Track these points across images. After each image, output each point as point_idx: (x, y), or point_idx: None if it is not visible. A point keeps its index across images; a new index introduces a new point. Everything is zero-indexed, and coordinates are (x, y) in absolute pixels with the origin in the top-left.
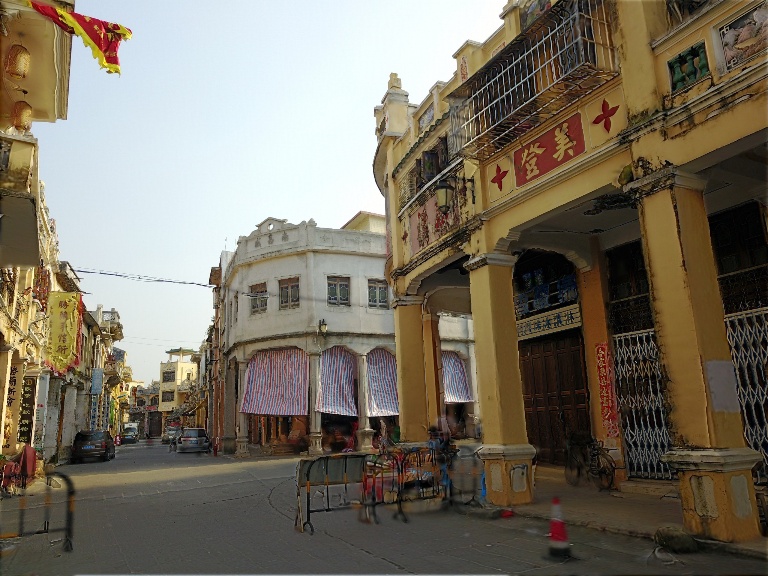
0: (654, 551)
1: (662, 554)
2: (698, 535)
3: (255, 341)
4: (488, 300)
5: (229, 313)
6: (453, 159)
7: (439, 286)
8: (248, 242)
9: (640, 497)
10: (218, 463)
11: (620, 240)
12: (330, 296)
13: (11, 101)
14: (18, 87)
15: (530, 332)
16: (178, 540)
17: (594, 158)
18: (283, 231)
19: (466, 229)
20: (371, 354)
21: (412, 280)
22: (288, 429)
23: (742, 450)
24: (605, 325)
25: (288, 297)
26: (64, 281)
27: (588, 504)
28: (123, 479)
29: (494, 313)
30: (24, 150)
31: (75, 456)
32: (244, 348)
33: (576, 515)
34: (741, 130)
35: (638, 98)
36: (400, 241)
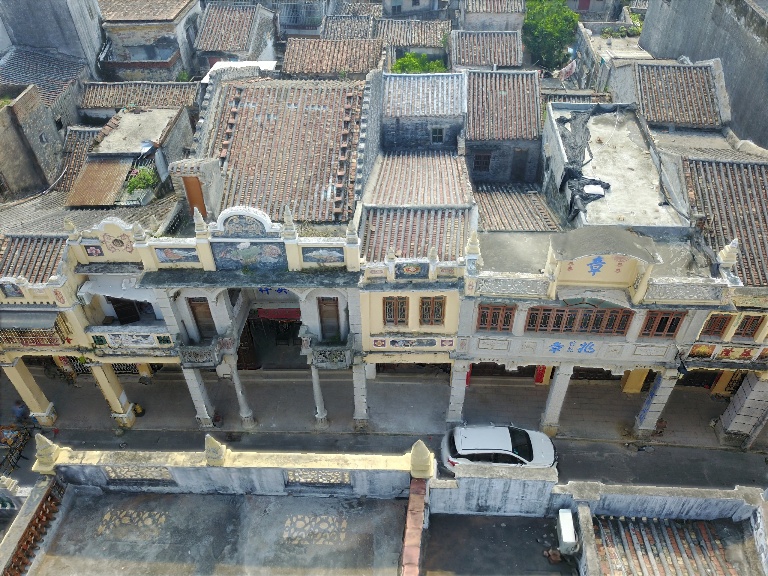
0: (120, 446)
1: (122, 446)
2: (124, 426)
3: None
4: None
5: None
6: None
7: None
8: None
9: (86, 385)
10: None
11: None
12: None
13: None
14: None
15: None
16: None
17: None
18: None
19: None
20: None
21: None
22: None
23: (130, 408)
24: None
25: None
26: None
27: (75, 405)
28: None
29: None
30: None
31: None
32: None
33: (81, 422)
34: None
35: (83, 343)
36: None
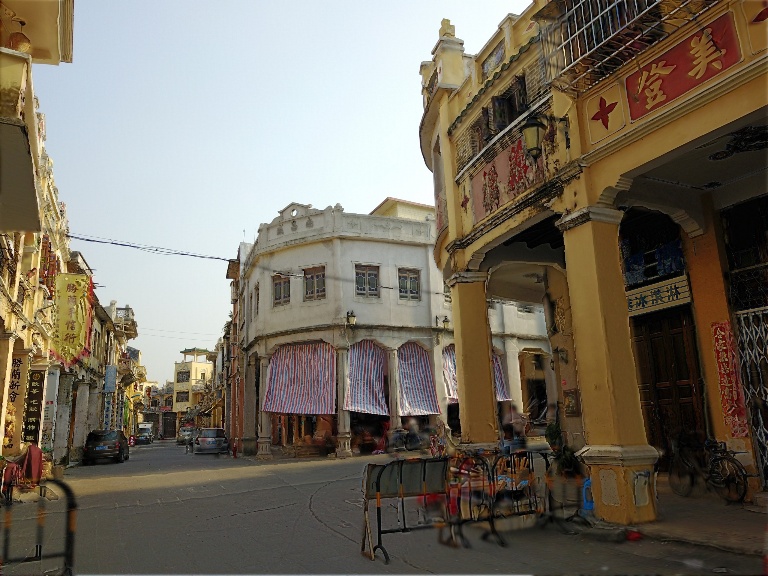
0: None
1: None
2: None
3: (278, 335)
4: (592, 264)
5: (249, 306)
6: (534, 100)
7: (504, 261)
8: (270, 229)
9: None
10: (240, 465)
11: (744, 195)
12: (358, 286)
13: (5, 31)
14: (14, 15)
15: None
16: (210, 568)
17: (760, 64)
18: (307, 217)
19: (556, 181)
20: (402, 348)
21: (475, 252)
22: (312, 429)
23: None
24: (725, 300)
25: (313, 287)
26: (75, 271)
27: (731, 522)
28: (138, 483)
29: (601, 280)
30: (13, 66)
31: (87, 457)
32: (266, 342)
33: (735, 539)
34: None
35: None
36: (458, 208)
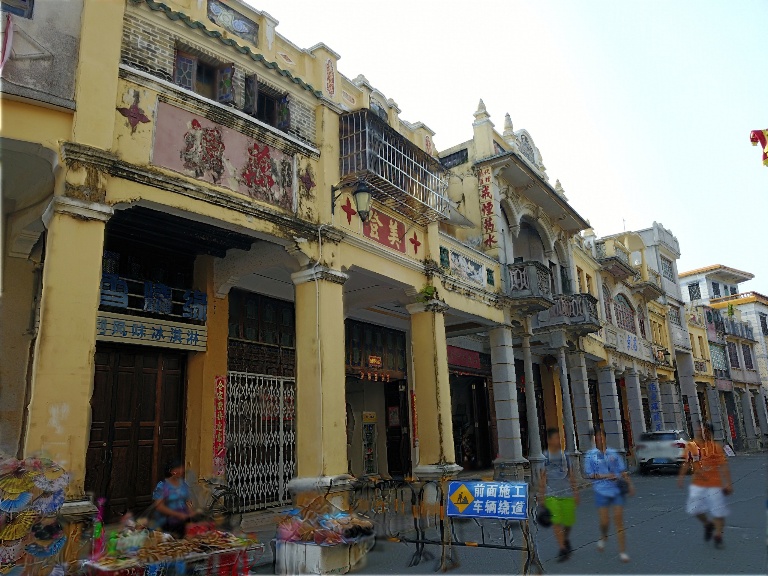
0: None
1: None
2: None
3: None
4: None
5: None
6: None
7: None
8: None
9: (267, 528)
10: None
11: (248, 285)
12: None
13: None
14: None
15: (120, 334)
16: None
17: (416, 266)
18: None
19: (315, 228)
20: None
21: (141, 199)
22: None
23: None
24: None
25: None
26: None
27: None
28: None
29: None
30: None
31: None
32: None
33: None
34: (463, 307)
35: None
36: None
